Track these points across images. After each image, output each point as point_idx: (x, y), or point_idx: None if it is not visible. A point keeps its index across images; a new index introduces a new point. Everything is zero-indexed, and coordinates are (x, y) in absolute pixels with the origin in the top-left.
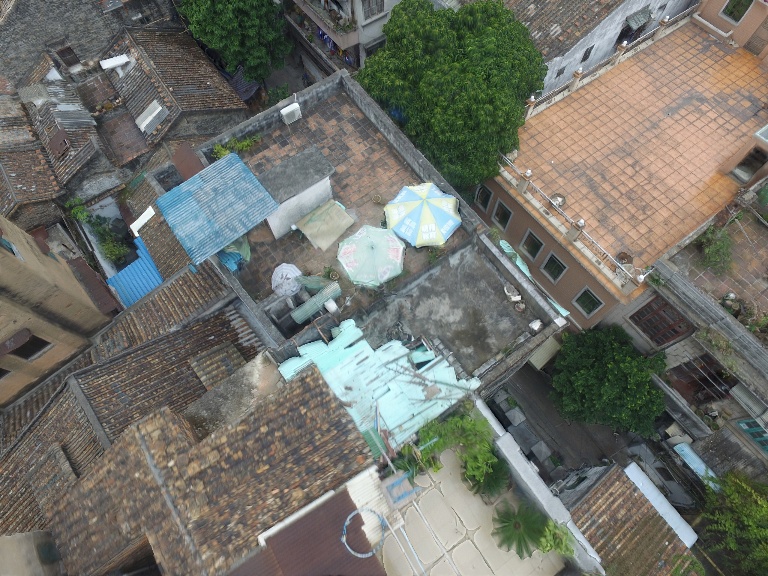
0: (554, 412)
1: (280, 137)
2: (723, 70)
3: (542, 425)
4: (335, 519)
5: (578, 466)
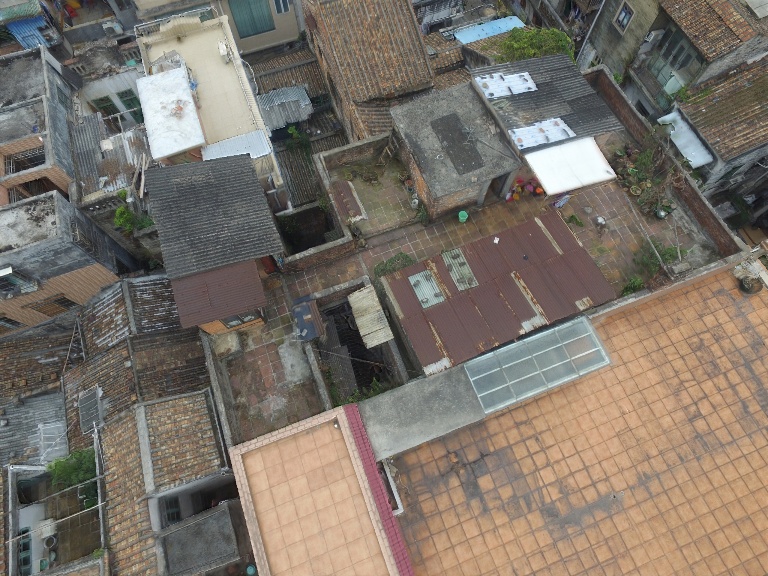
0: None
1: None
2: (486, 570)
3: None
4: None
5: None
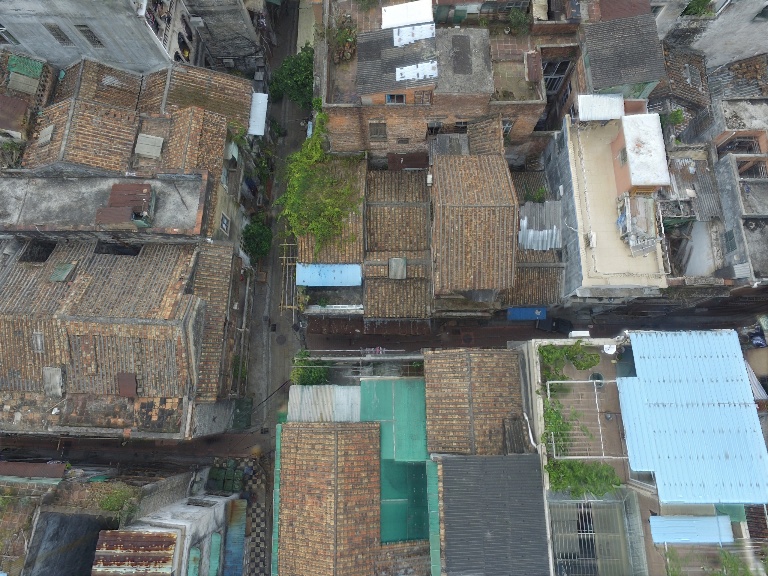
0: (302, 112)
1: None
2: None
3: (290, 114)
4: None
5: (290, 142)
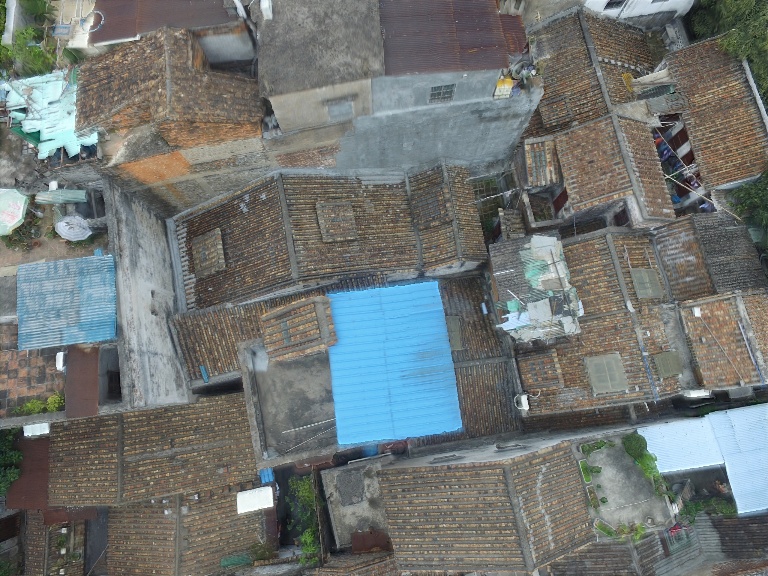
0: None
1: (0, 405)
2: None
3: None
4: (101, 33)
5: None
